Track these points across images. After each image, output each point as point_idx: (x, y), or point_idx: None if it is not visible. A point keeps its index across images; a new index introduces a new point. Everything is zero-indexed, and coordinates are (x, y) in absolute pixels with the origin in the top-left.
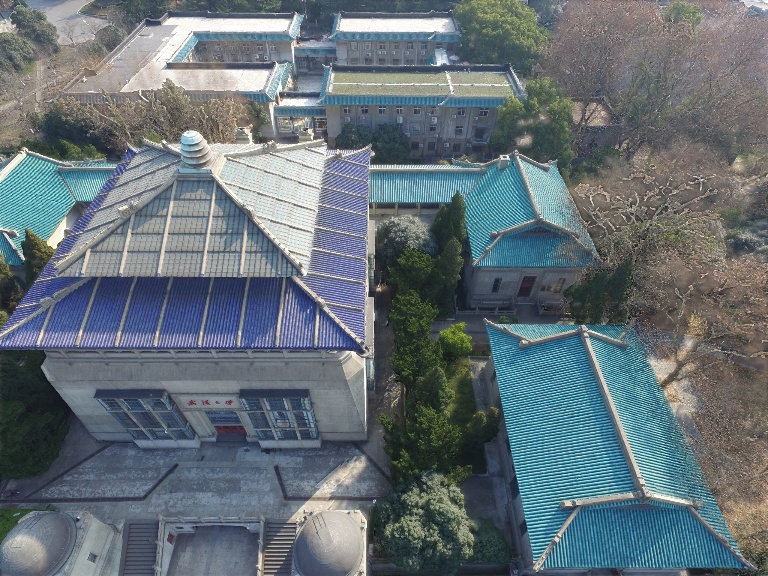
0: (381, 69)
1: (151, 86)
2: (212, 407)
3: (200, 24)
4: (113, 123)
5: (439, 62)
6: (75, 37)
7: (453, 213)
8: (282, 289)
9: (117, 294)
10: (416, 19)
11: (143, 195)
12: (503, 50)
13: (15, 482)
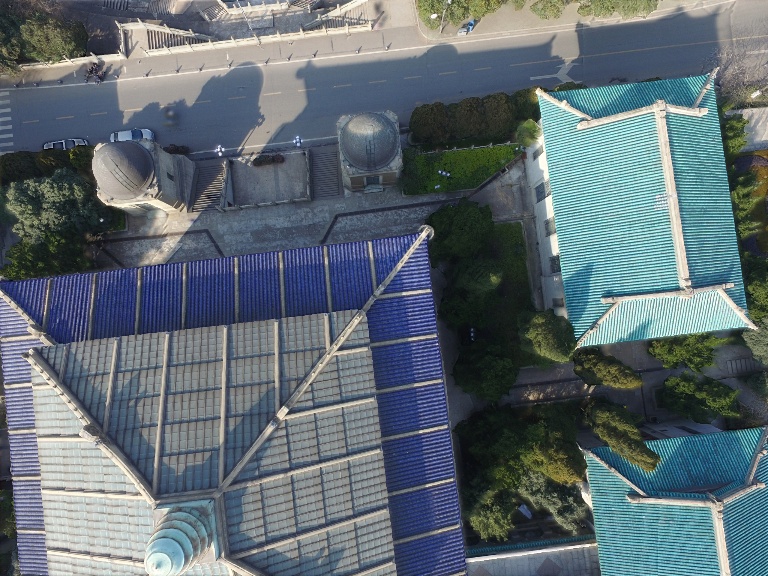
0: None
1: None
2: None
3: None
4: None
5: None
6: None
7: None
8: None
9: (302, 315)
10: None
11: (285, 462)
12: None
13: None
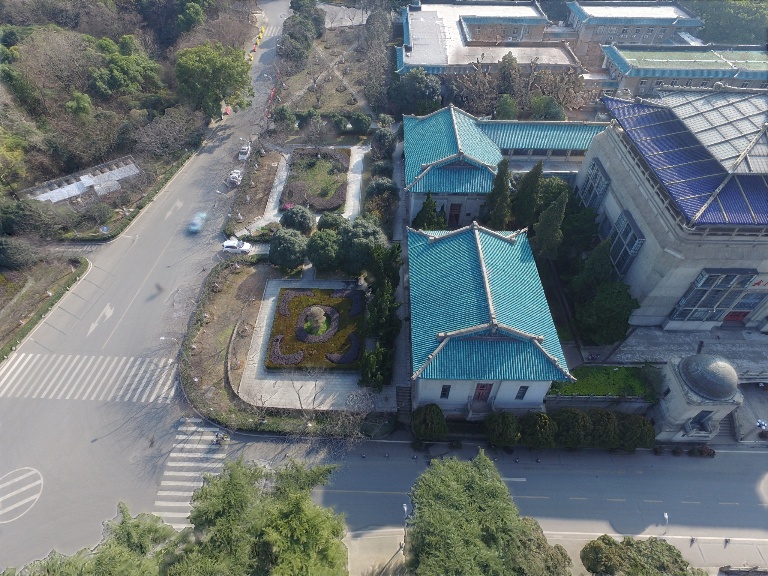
0: (655, 48)
1: (471, 60)
2: (766, 288)
3: (455, 10)
4: (454, 90)
5: (693, 43)
6: (335, 21)
7: None
8: None
9: (757, 189)
10: (644, 7)
11: (752, 118)
12: (757, 33)
13: (586, 351)
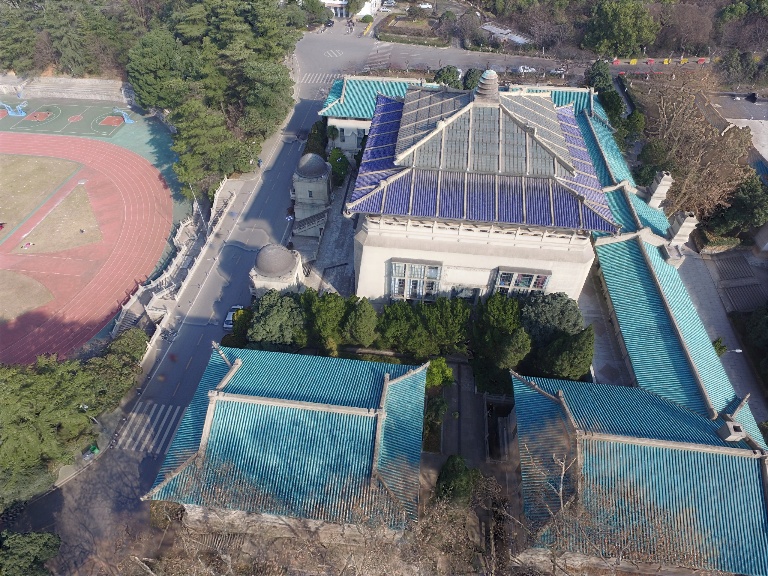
0: None
1: (756, 132)
2: None
3: None
4: None
5: None
6: None
7: (571, 336)
8: (397, 168)
9: None
10: None
11: None
12: None
13: None
